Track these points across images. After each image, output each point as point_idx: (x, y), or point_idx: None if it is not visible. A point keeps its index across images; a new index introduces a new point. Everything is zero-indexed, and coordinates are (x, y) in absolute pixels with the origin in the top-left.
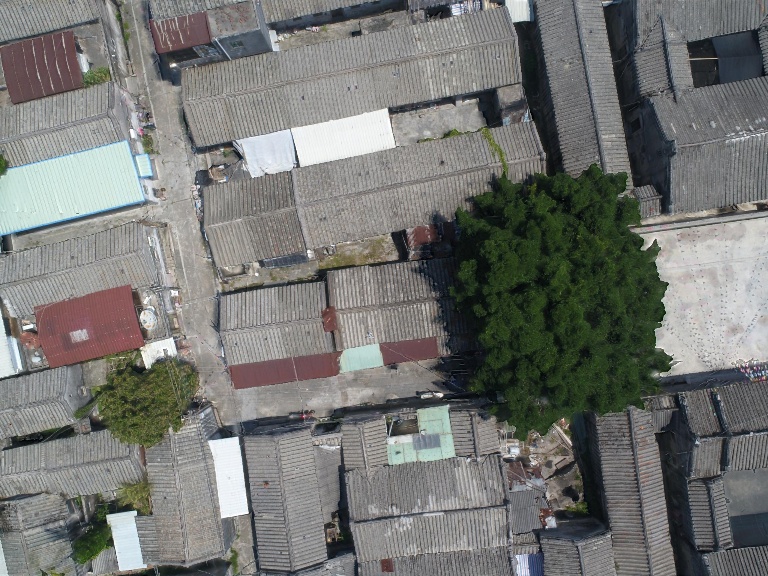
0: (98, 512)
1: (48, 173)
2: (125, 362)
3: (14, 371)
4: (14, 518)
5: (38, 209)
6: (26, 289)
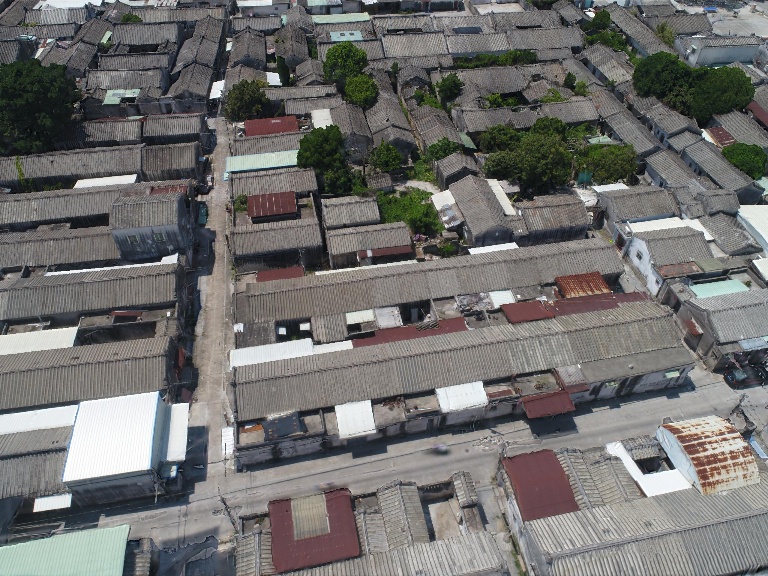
0: None
1: None
2: None
3: None
4: None
5: None
6: None
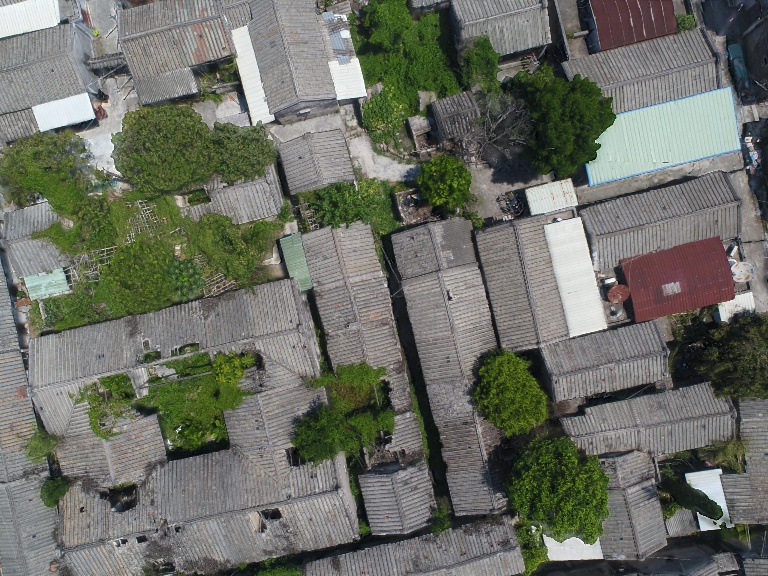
0: (665, 472)
1: (646, 121)
2: (689, 318)
3: (606, 325)
4: (610, 476)
5: (631, 158)
6: (618, 241)
